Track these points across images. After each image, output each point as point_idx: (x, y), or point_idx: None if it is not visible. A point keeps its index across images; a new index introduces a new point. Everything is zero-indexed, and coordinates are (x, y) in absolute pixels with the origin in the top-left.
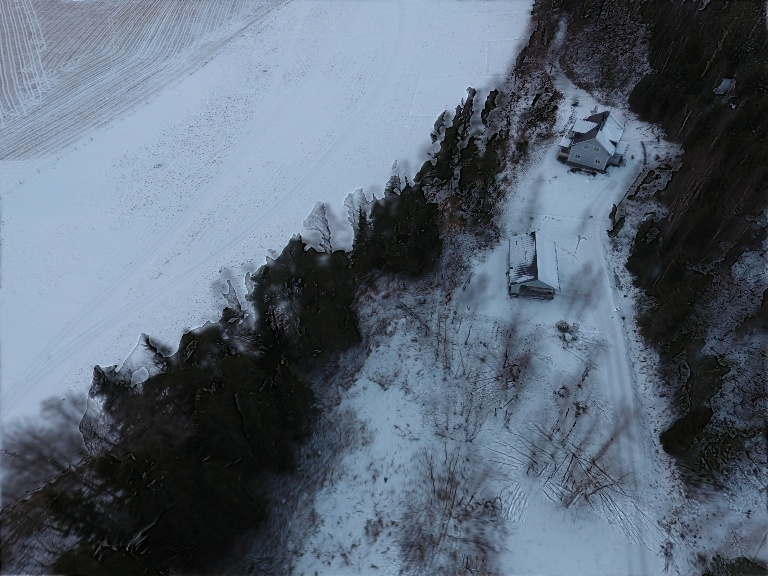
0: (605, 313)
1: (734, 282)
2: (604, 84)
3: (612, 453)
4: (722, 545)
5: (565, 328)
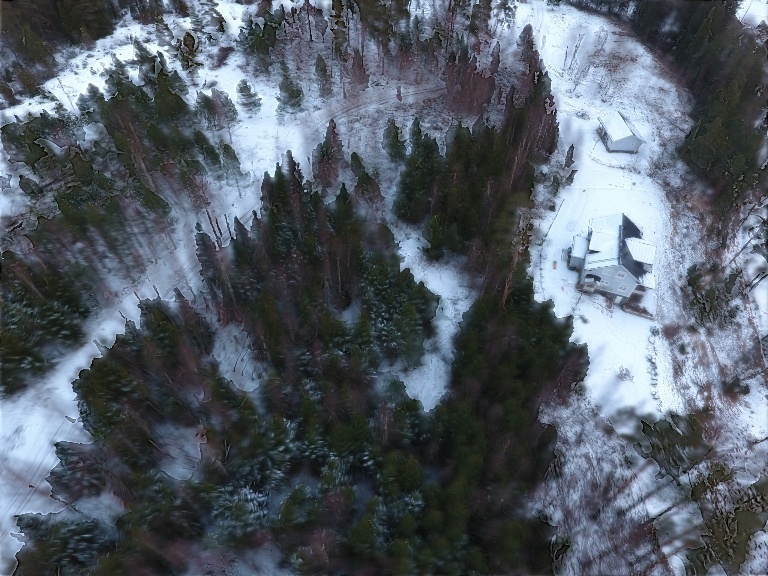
0: (563, 124)
1: (491, 127)
2: (631, 537)
3: (554, 80)
4: (517, 63)
5: (585, 114)
